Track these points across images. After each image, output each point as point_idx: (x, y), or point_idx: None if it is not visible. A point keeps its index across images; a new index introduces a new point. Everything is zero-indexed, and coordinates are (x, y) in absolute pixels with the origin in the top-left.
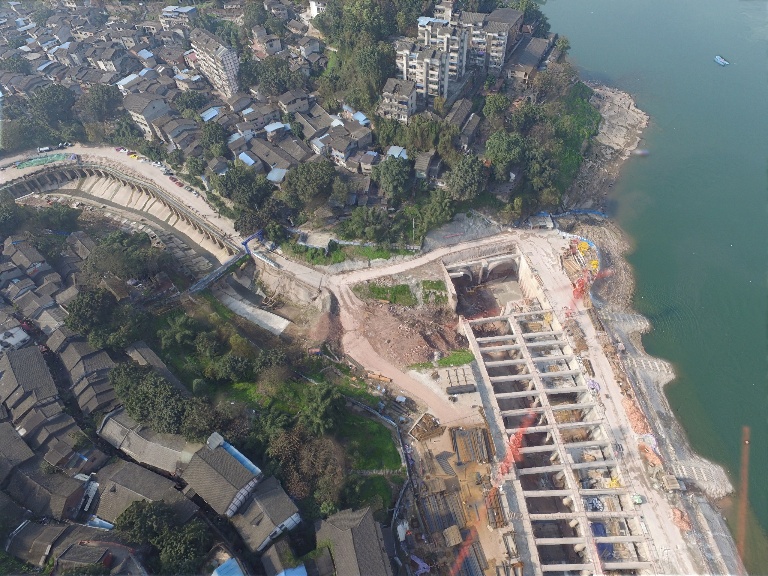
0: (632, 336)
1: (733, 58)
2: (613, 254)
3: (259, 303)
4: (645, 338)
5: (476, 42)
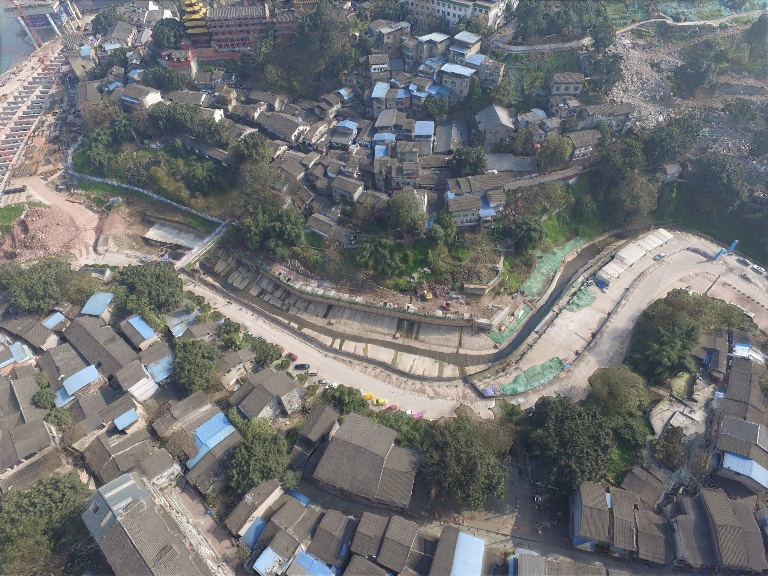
0: None
1: None
2: None
3: (176, 254)
4: None
5: None
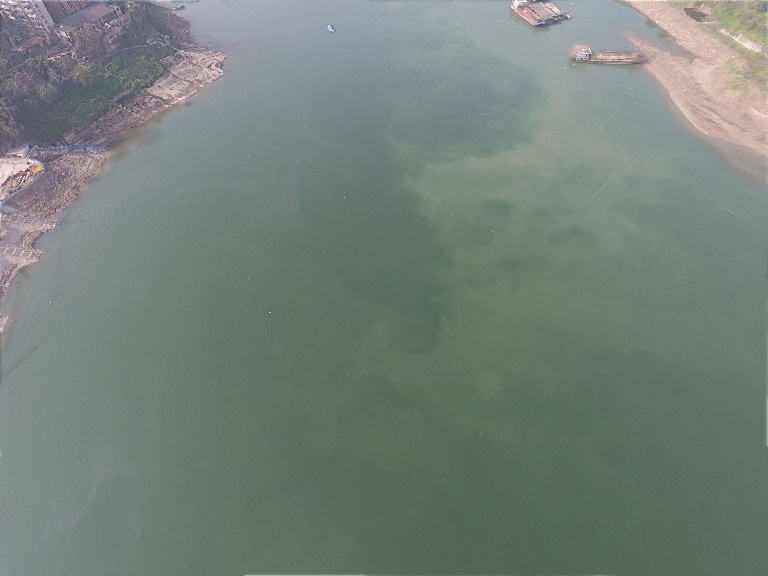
0: (31, 234)
1: (341, 26)
2: (73, 176)
3: None
4: (44, 236)
5: (12, 5)
